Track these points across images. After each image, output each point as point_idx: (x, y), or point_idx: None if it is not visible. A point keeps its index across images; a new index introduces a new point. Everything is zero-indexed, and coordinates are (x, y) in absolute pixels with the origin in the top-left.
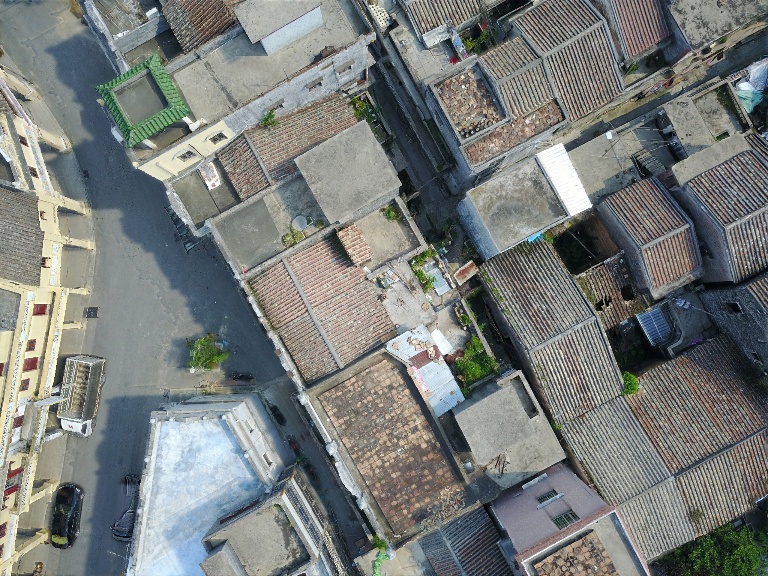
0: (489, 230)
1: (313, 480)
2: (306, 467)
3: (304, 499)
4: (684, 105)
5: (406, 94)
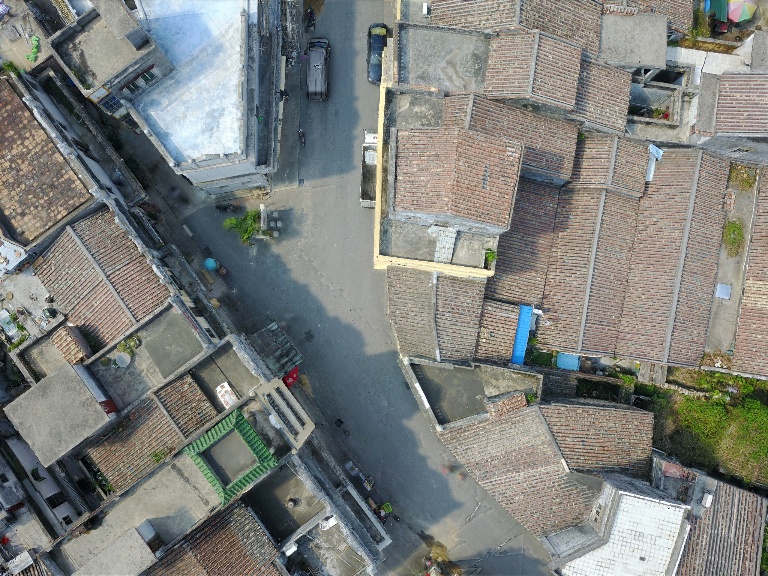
0: None
1: None
2: None
3: None
4: None
5: (72, 503)
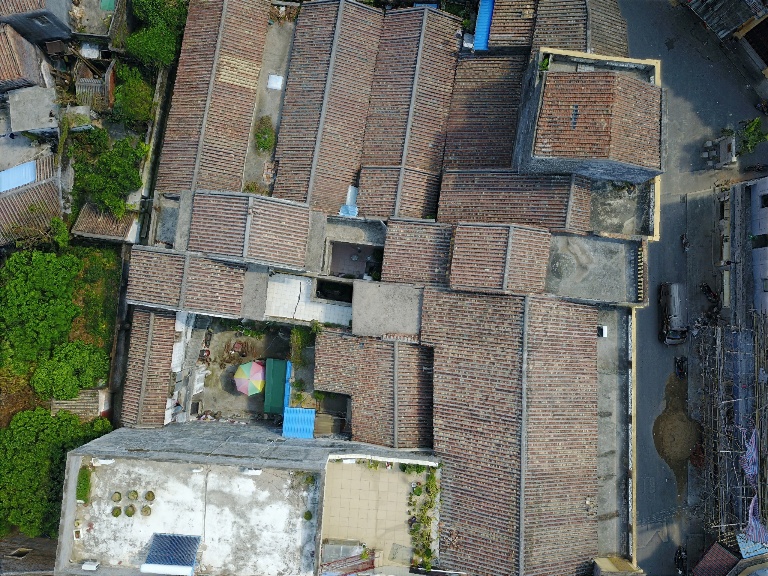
0: None
1: None
2: None
3: None
4: None
5: None
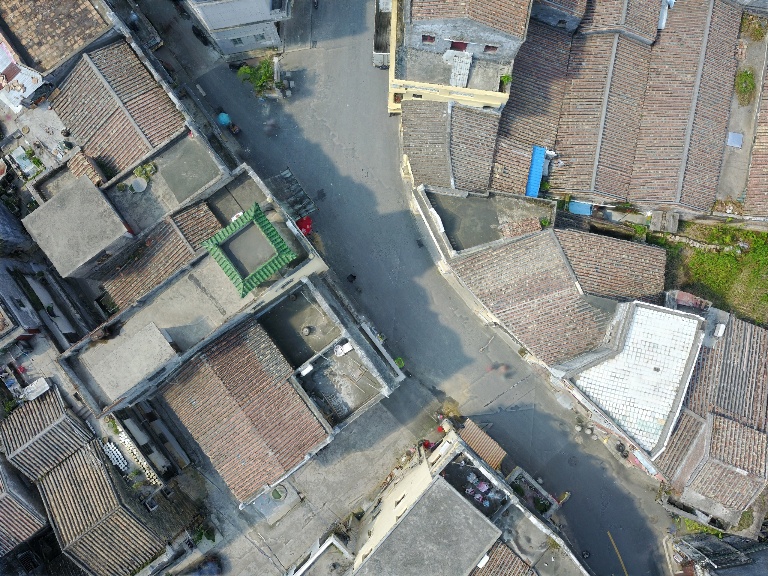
0: None
1: None
2: None
3: None
4: None
5: None
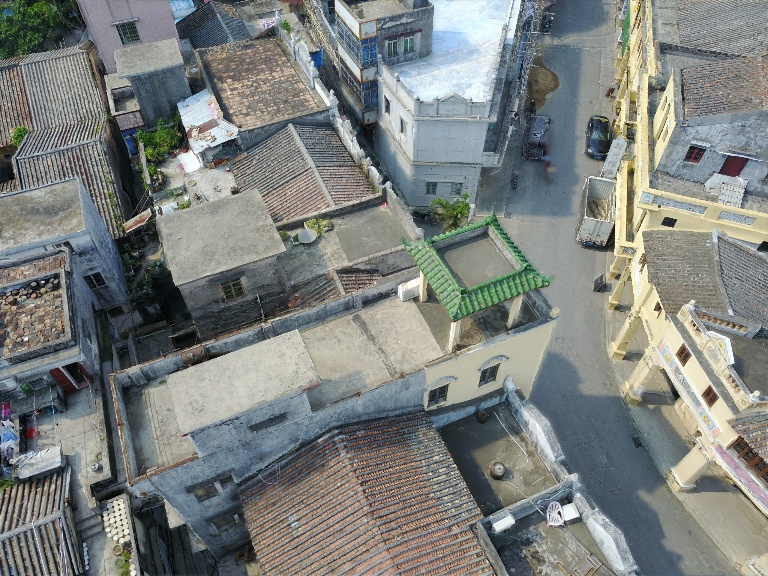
0: (79, 196)
1: (360, 140)
2: (365, 146)
3: (352, 67)
4: None
5: None
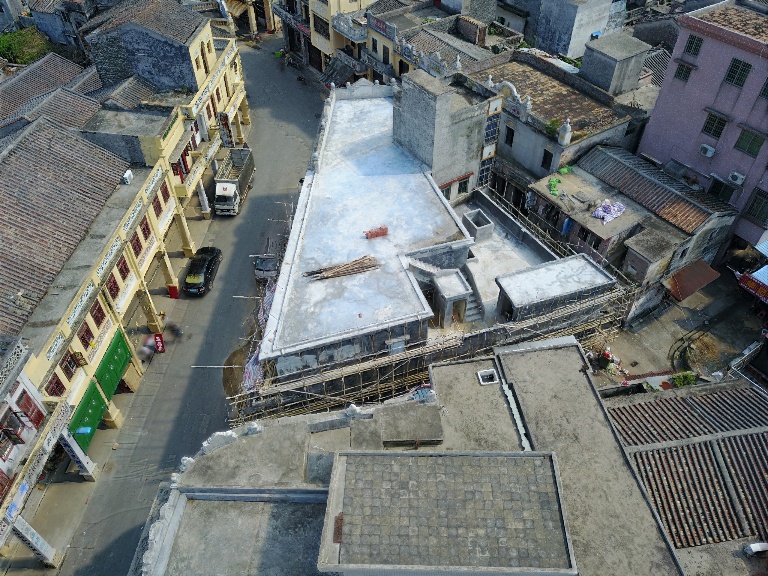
0: None
1: None
2: None
3: None
4: (662, 6)
5: None
